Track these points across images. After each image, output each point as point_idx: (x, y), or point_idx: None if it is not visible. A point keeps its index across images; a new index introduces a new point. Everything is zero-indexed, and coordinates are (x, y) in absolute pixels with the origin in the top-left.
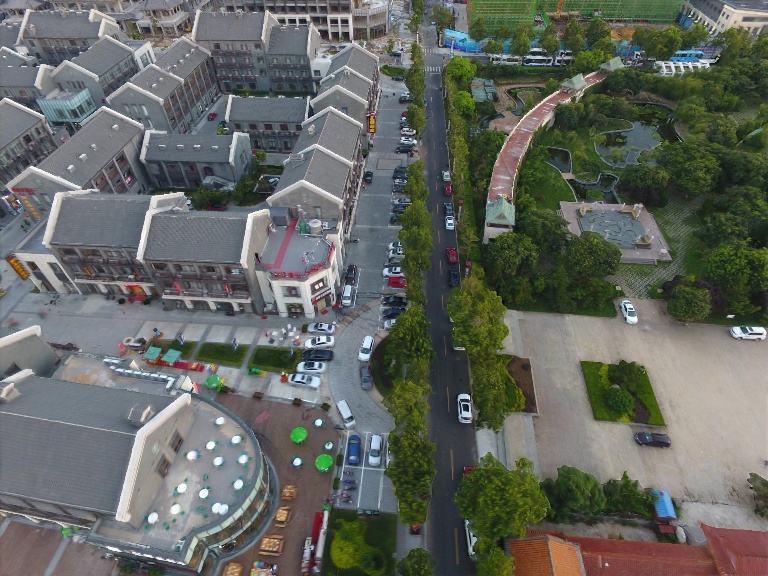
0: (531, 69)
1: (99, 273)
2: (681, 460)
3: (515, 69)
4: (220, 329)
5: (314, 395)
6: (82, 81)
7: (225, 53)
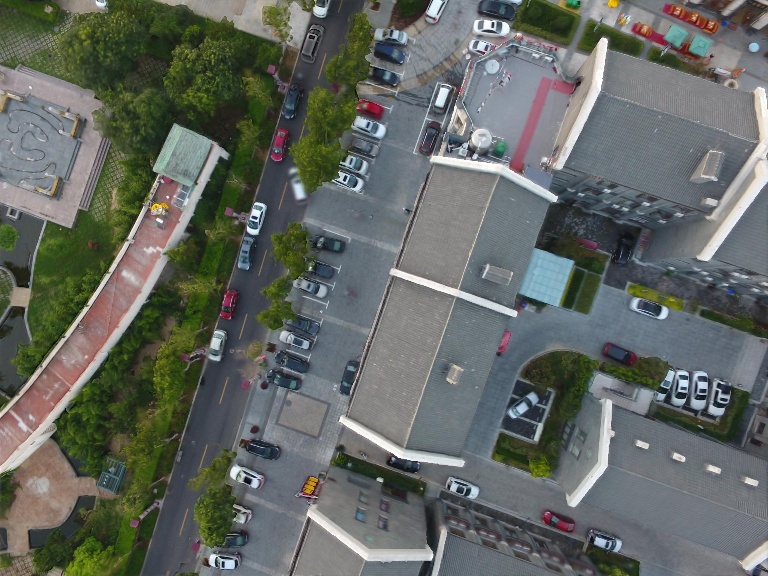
0: None
1: None
2: None
3: None
4: None
5: None
6: None
7: None
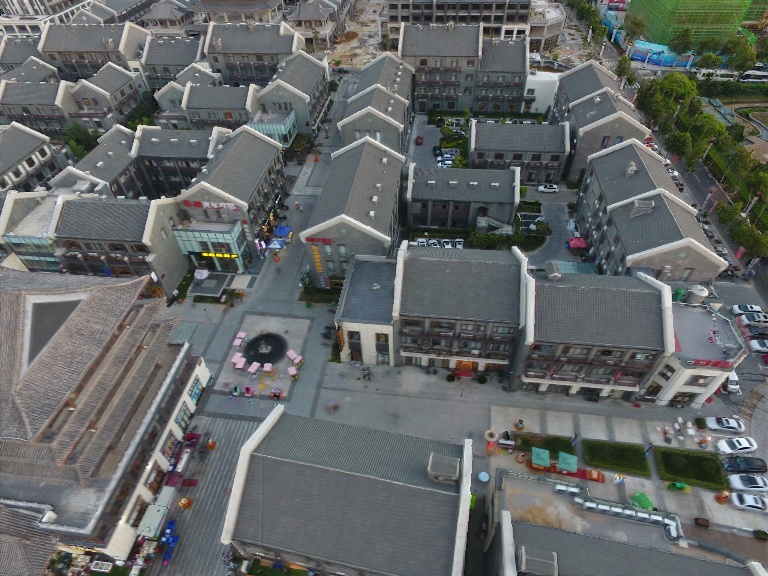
0: (753, 86)
1: (433, 346)
2: None
3: (738, 86)
4: (590, 420)
5: None
6: (290, 102)
7: (431, 70)
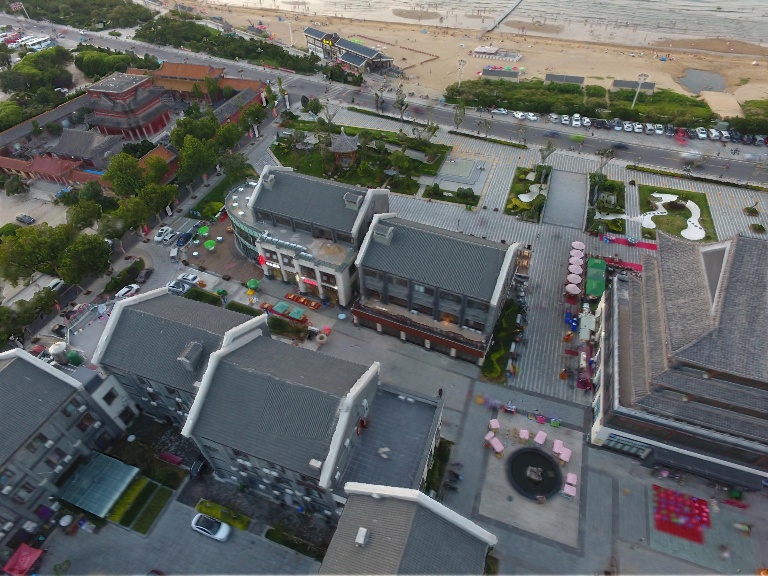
0: None
1: None
2: (26, 213)
3: None
4: None
5: (188, 272)
6: None
7: None
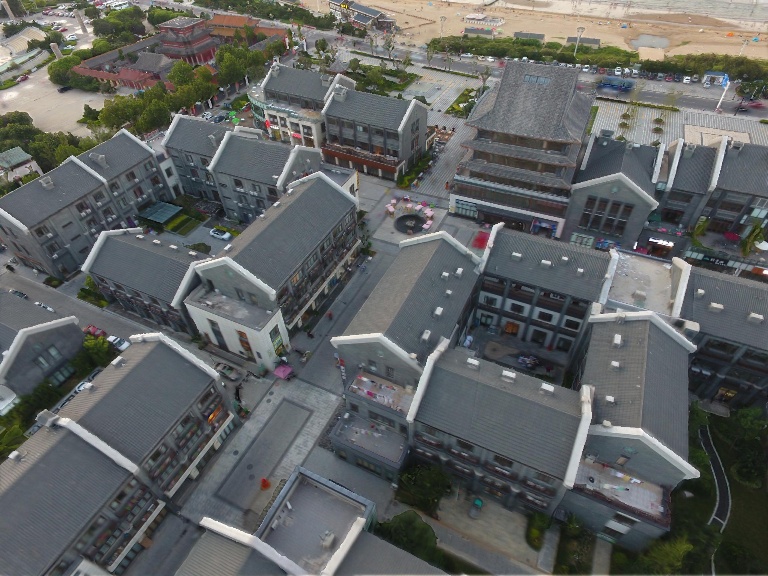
0: None
1: None
2: None
3: None
4: None
5: None
6: None
7: None
